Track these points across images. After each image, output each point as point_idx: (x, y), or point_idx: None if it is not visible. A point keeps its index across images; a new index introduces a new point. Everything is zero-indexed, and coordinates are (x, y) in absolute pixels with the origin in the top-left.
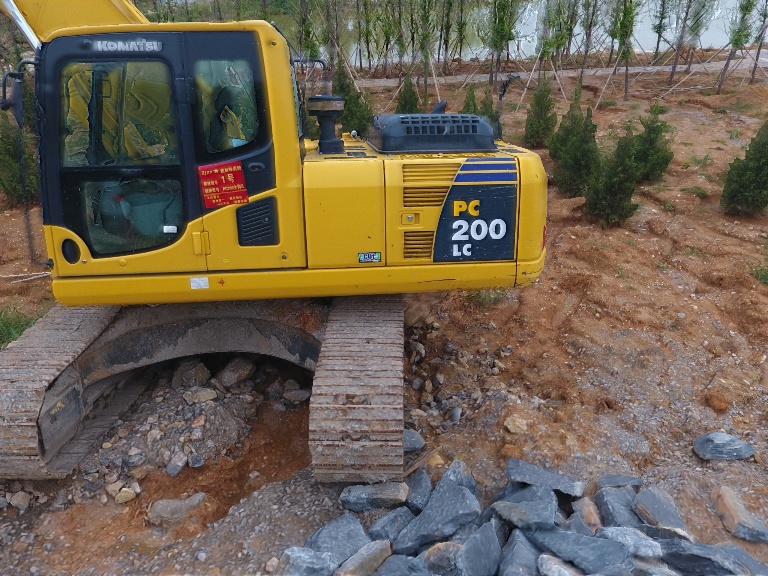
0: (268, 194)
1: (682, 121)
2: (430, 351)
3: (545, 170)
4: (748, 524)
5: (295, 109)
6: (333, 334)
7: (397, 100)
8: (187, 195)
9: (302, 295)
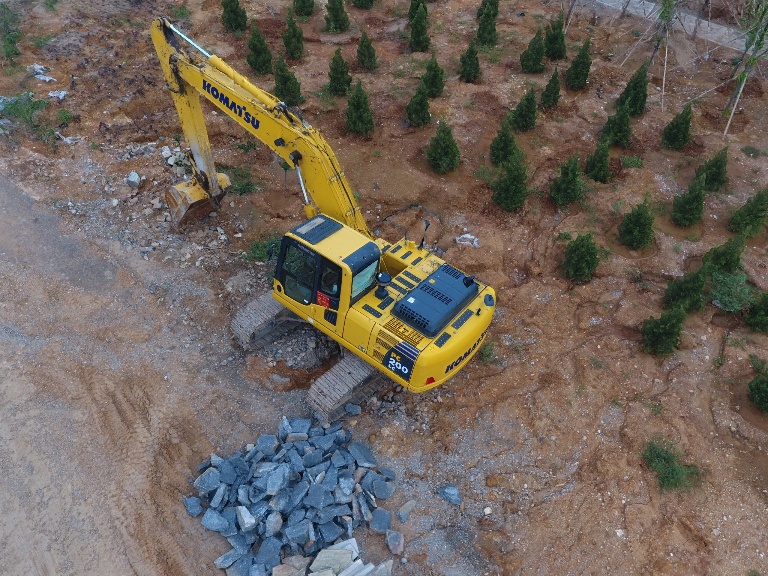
0: (335, 311)
1: None
2: None
3: (696, 266)
4: (401, 513)
5: (350, 293)
6: (344, 362)
7: (724, 84)
8: (313, 296)
9: None
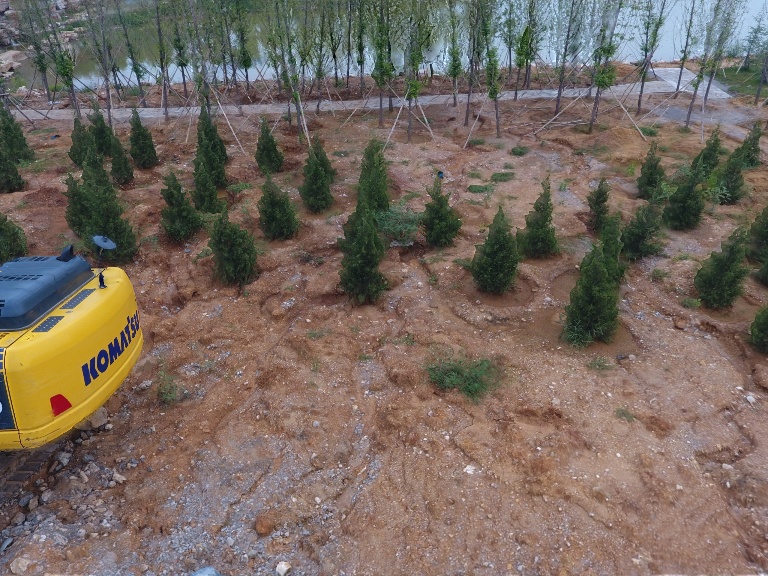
0: None
1: (531, 166)
2: (73, 460)
3: None
4: None
5: None
6: None
7: (287, 131)
8: None
9: None
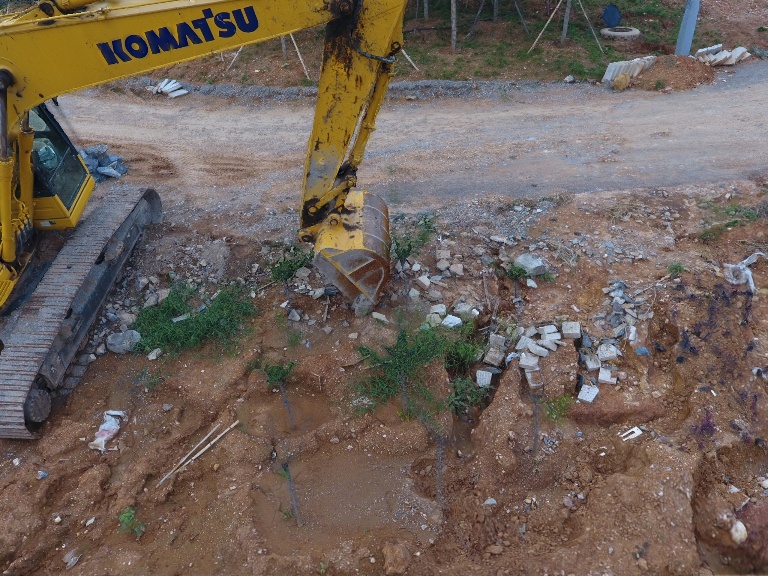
0: None
1: None
2: None
3: None
4: None
5: None
6: None
7: None
8: None
9: None
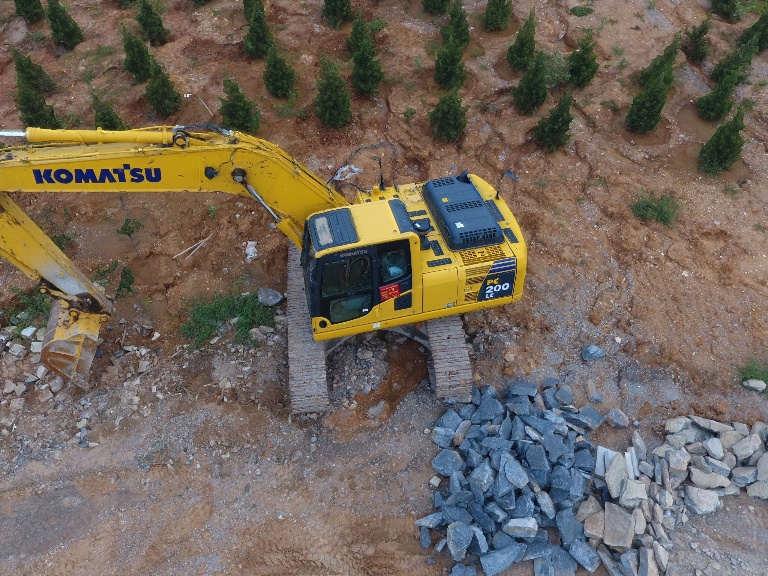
0: (408, 292)
1: None
2: None
3: (504, 71)
4: (596, 397)
5: None
6: (433, 334)
7: None
8: (374, 298)
9: (419, 321)
